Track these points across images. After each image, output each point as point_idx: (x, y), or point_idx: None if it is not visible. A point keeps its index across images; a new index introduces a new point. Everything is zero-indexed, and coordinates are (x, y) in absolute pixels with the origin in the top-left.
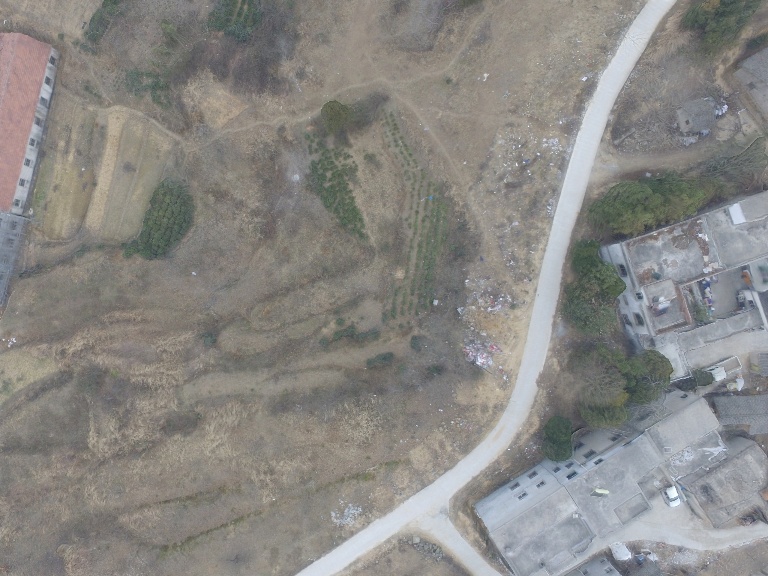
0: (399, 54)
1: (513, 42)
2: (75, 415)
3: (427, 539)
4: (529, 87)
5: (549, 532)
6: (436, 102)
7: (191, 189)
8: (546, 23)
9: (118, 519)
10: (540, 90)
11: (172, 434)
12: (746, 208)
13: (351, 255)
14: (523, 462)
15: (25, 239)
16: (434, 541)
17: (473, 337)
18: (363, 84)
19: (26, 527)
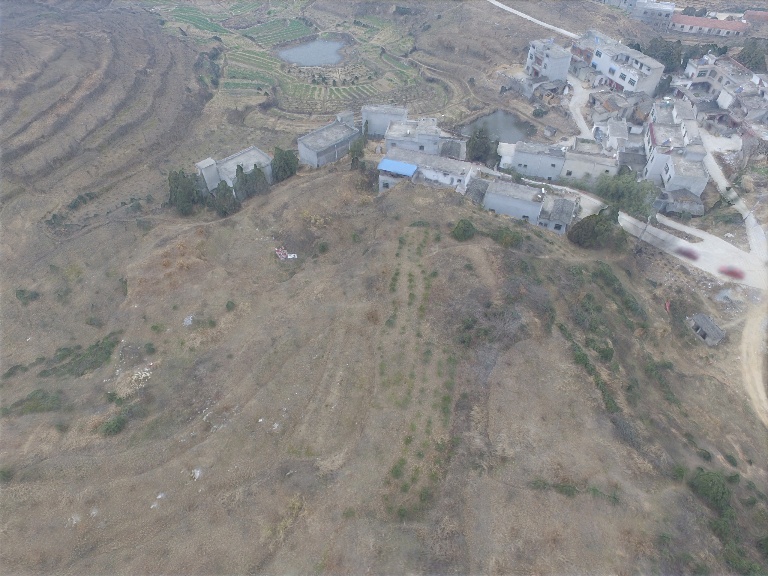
0: None
1: None
2: None
3: None
4: None
5: (592, 46)
6: None
7: None
8: None
9: None
10: None
11: None
12: (760, 74)
13: None
14: None
15: None
16: None
17: None
18: None
19: None
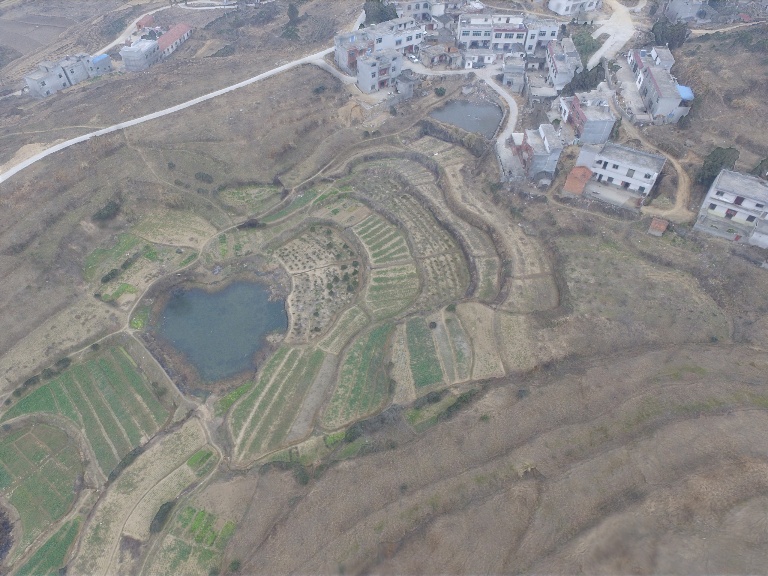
0: None
1: None
2: None
3: None
4: (356, 1)
5: None
6: None
7: None
8: None
9: None
10: (359, 1)
11: None
12: None
13: None
14: None
15: None
16: None
17: None
18: None
19: None
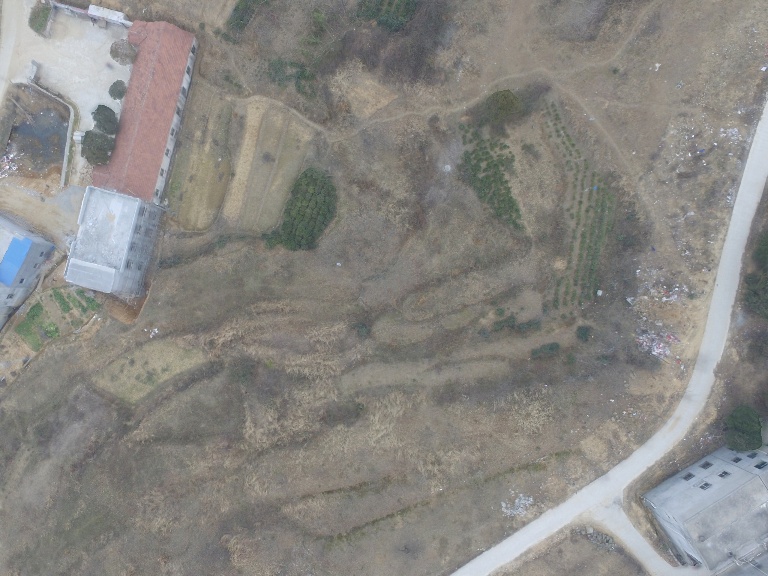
0: (561, 44)
1: (685, 32)
2: (228, 405)
3: (599, 529)
4: (704, 77)
5: (736, 522)
6: (602, 92)
7: (334, 179)
8: (721, 13)
9: (281, 509)
10: (716, 80)
11: (334, 424)
12: None
13: (504, 246)
14: (695, 452)
15: (160, 229)
16: (606, 531)
17: (645, 327)
18: (521, 74)
19: (183, 518)
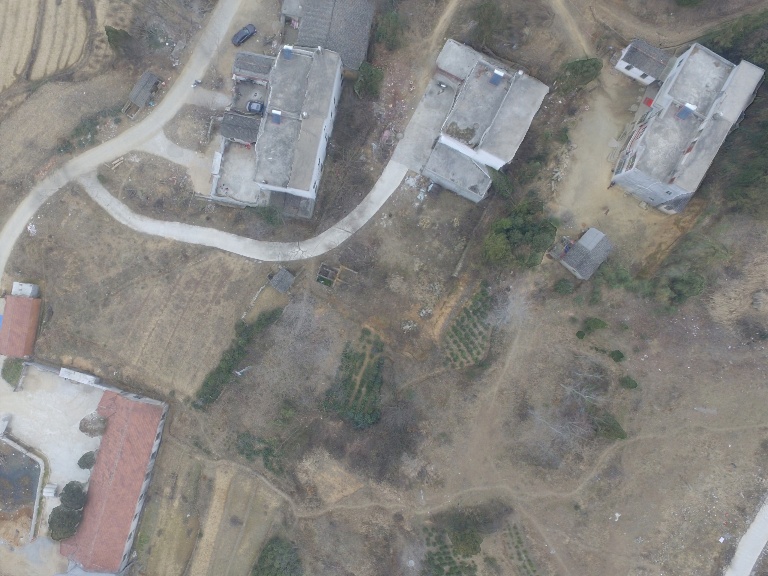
0: (524, 468)
1: (646, 484)
2: None
3: None
4: (663, 536)
5: None
6: (563, 526)
7: (300, 551)
8: (681, 472)
9: None
10: (674, 541)
11: None
12: None
13: None
14: None
15: None
16: None
17: None
18: (485, 488)
19: None
